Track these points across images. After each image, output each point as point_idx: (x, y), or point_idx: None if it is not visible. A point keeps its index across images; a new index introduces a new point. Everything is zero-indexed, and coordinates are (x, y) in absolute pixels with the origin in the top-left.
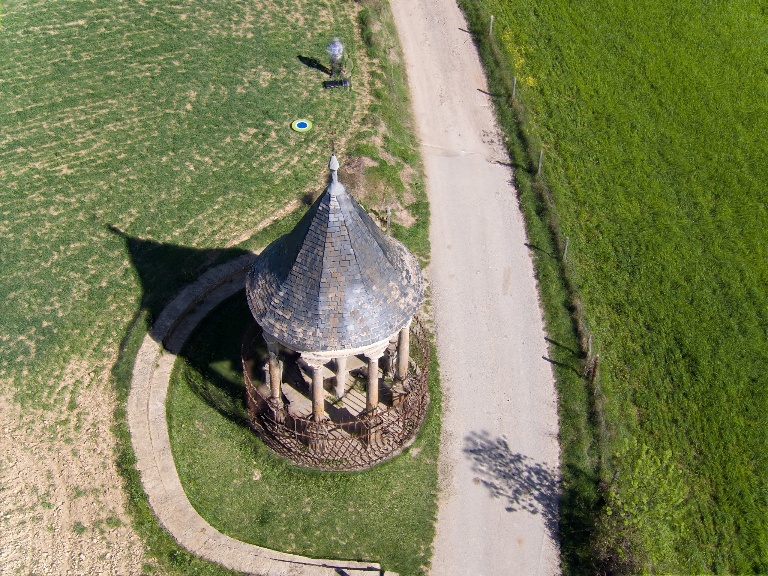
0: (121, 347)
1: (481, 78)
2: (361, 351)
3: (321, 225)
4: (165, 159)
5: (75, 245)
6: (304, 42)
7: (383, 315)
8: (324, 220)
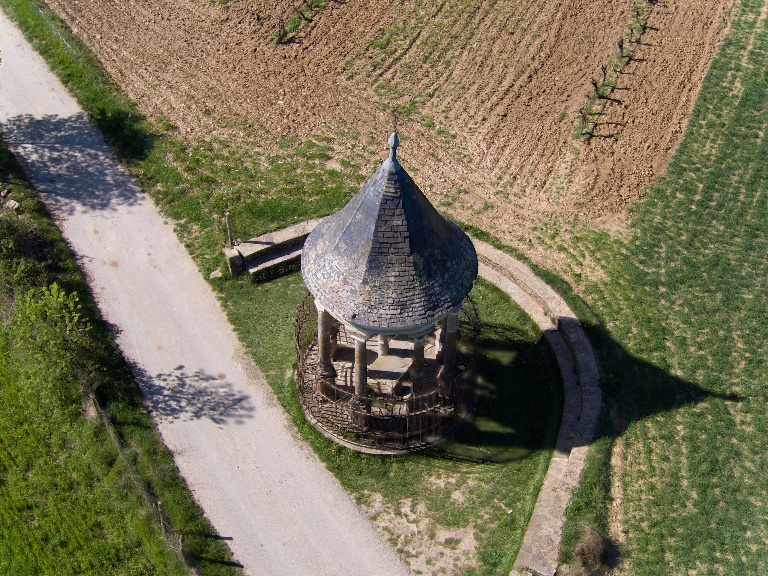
0: None
1: None
2: None
3: None
4: None
5: (743, 364)
6: None
7: None
8: None
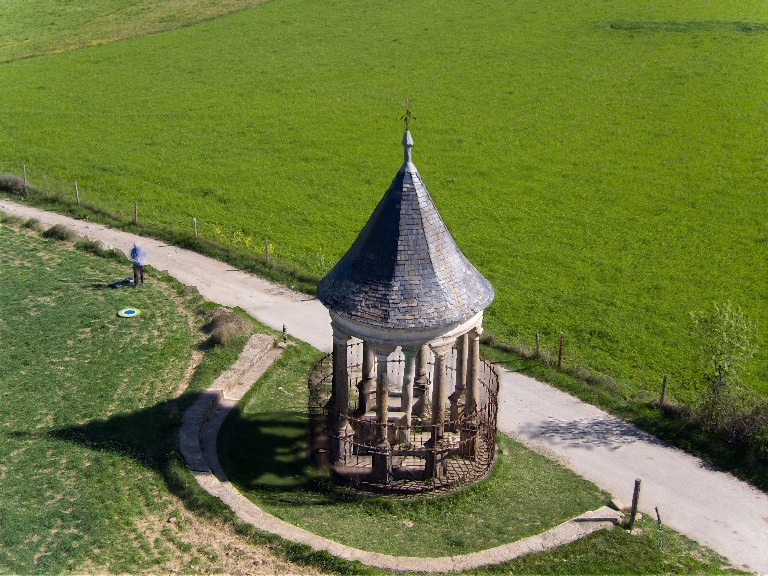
0: (175, 490)
1: (220, 264)
2: (475, 323)
3: (411, 205)
4: (23, 372)
5: (14, 454)
6: (50, 273)
7: (480, 280)
8: (413, 199)
